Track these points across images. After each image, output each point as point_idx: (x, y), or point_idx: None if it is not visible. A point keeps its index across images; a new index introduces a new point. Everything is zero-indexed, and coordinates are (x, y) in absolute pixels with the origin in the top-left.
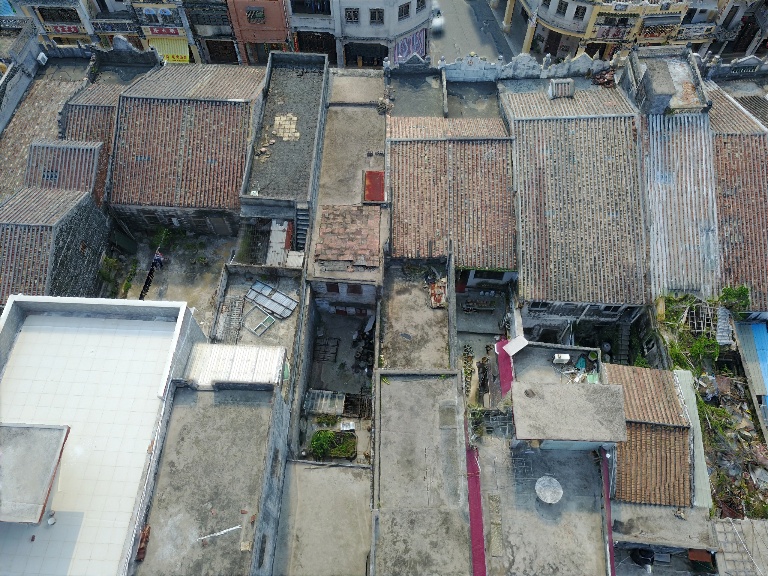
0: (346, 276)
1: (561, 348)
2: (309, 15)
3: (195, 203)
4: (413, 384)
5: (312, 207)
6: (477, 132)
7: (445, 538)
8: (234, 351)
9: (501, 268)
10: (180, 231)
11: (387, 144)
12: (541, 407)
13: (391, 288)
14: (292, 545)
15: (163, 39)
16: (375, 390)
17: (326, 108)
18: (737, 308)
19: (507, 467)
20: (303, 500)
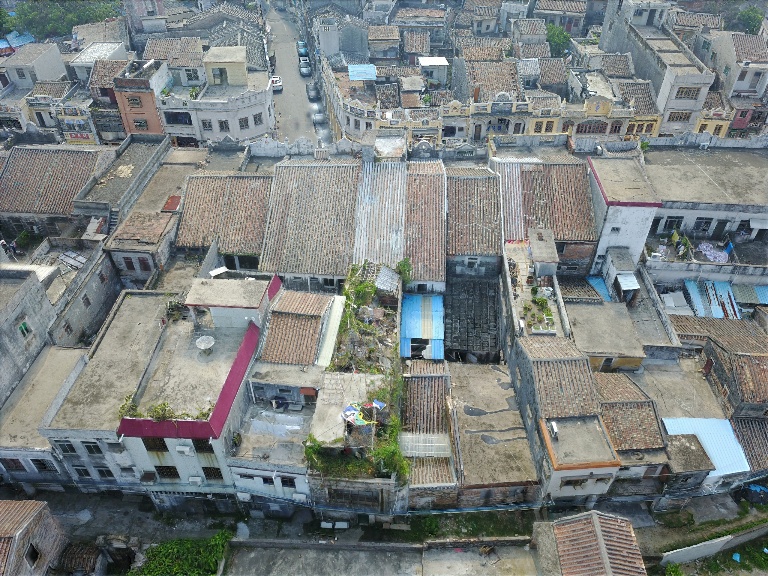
0: (132, 248)
1: (252, 276)
2: (178, 125)
3: (46, 210)
4: (147, 299)
5: (123, 211)
6: None
7: (129, 374)
8: (23, 267)
9: (251, 253)
10: (38, 236)
11: (186, 178)
12: (208, 290)
13: (172, 267)
14: (27, 389)
15: (79, 142)
16: (118, 300)
17: (160, 165)
18: (412, 278)
19: (187, 336)
20: (47, 366)
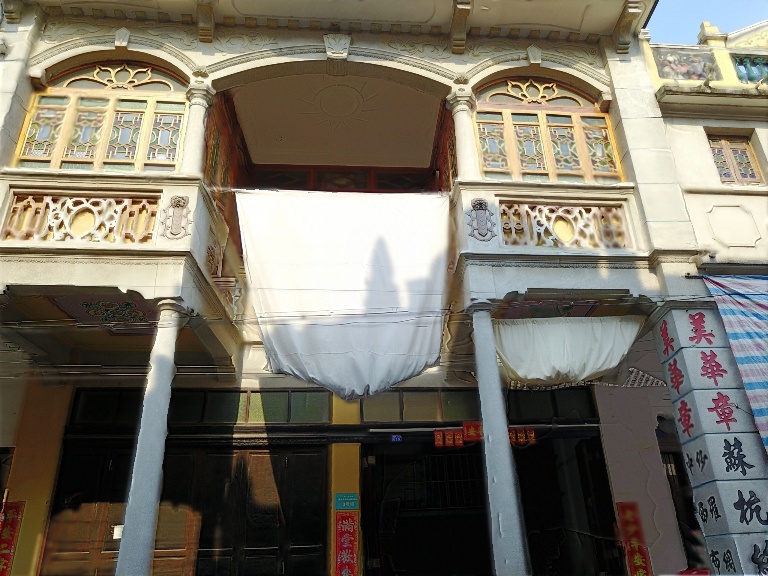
0: None
1: None
2: None
3: None
4: None
5: None
6: None
7: None
8: None
9: None
10: None
11: None
12: None
13: None
14: None
15: None
16: None
17: None
18: None
19: None
20: None
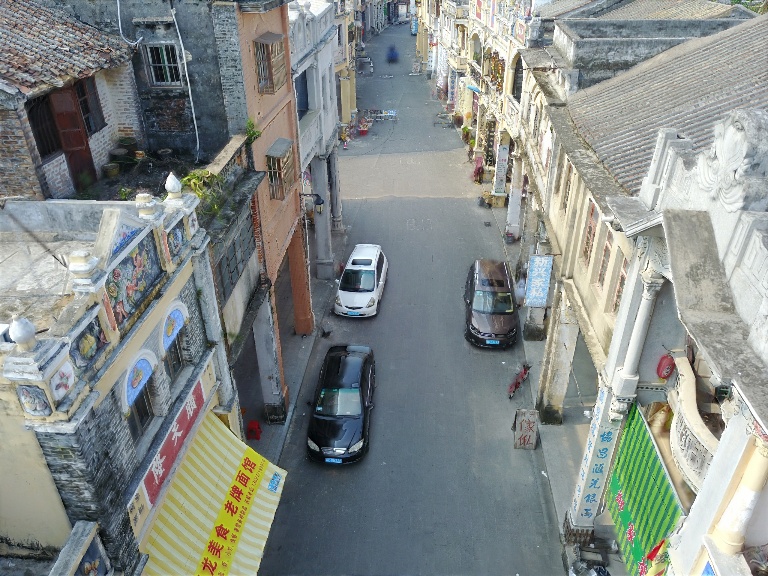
0: None
1: None
2: (303, 124)
3: None
4: None
5: None
6: (653, 4)
7: None
8: None
9: None
10: None
11: None
12: None
13: None
14: None
15: None
16: None
17: None
18: None
19: None
20: None
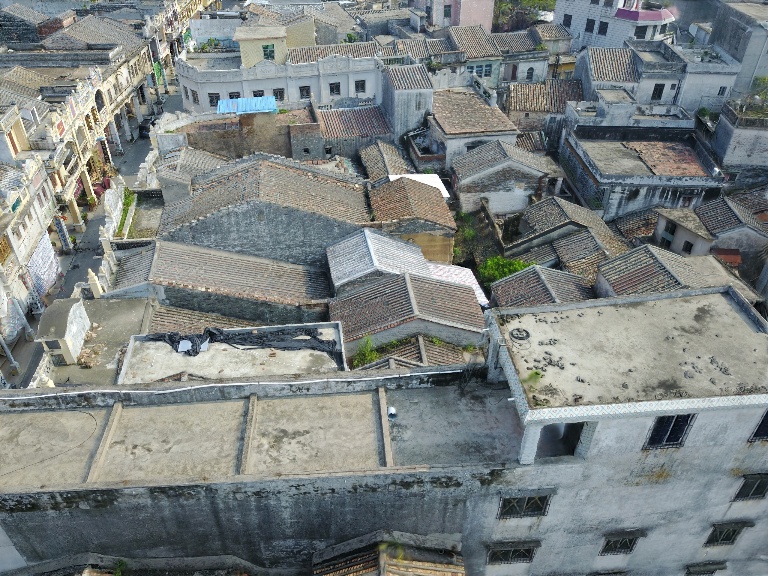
0: None
1: None
2: None
3: None
4: None
5: None
6: None
7: None
8: None
9: None
10: None
11: None
12: None
13: None
14: None
15: None
16: None
17: None
18: None
19: None
20: None
